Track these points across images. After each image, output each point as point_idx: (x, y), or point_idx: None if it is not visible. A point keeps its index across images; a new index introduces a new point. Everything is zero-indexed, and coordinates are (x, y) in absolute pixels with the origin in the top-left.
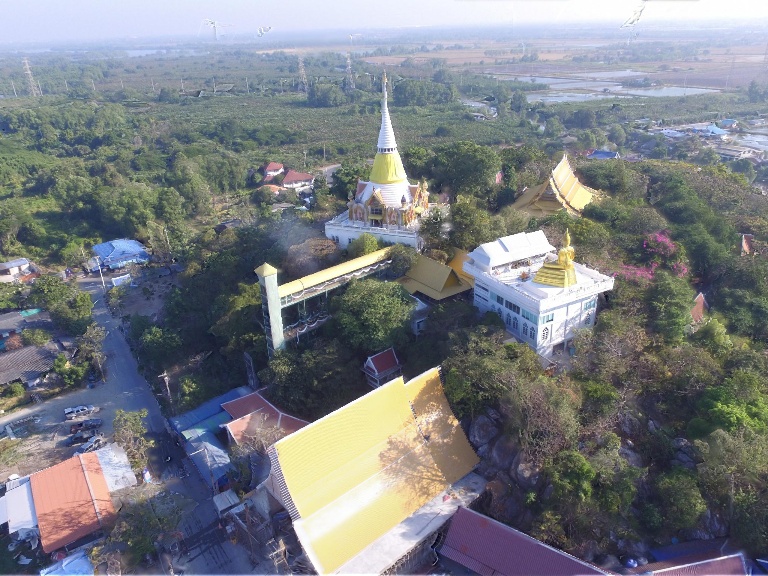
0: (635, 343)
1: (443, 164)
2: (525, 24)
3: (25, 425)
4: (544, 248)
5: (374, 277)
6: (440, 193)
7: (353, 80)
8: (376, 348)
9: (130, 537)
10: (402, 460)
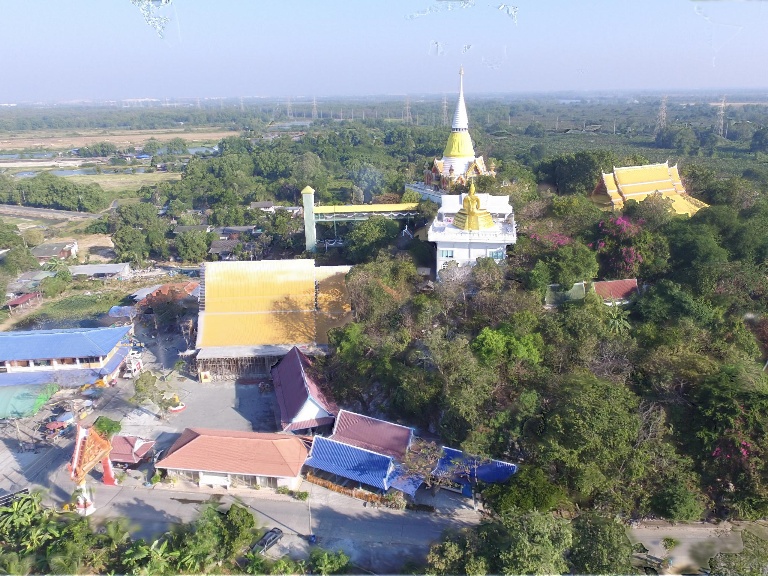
0: (484, 280)
1: (564, 163)
2: (720, 38)
3: None
4: (500, 209)
5: (410, 225)
6: (557, 190)
7: (726, 127)
8: (348, 257)
9: (151, 304)
10: (291, 313)
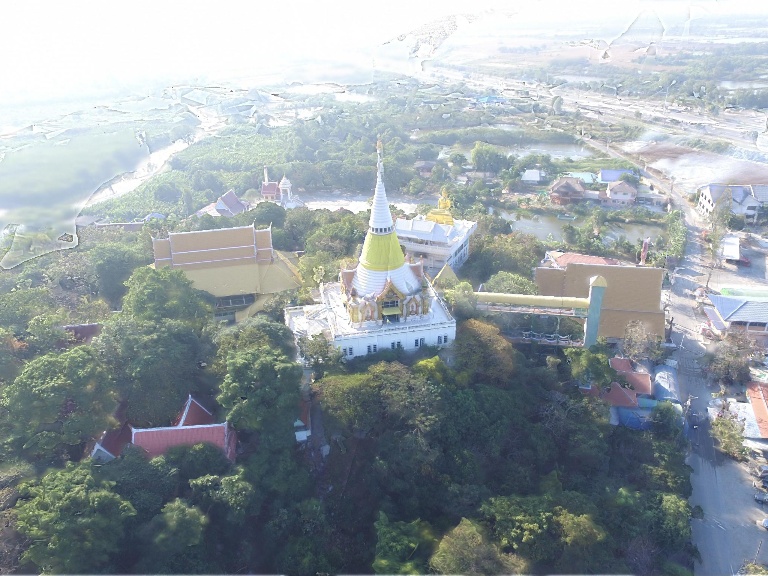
0: None
1: None
2: None
3: None
4: None
5: None
6: None
7: None
8: None
9: None
10: None
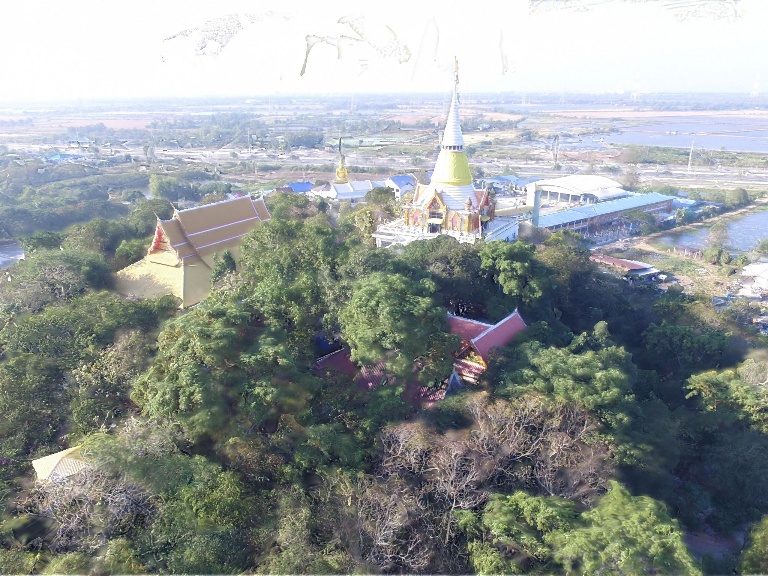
0: None
1: None
2: None
3: (715, 301)
4: None
5: None
6: None
7: None
8: None
9: None
10: None
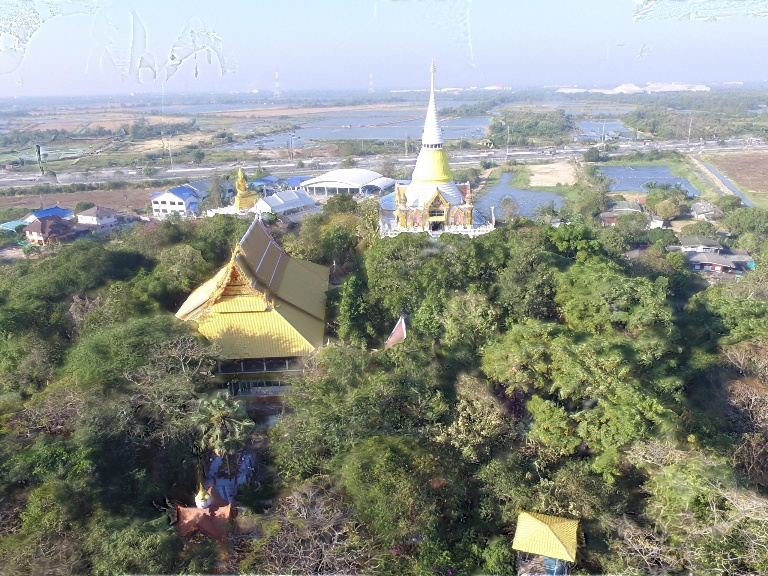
0: None
1: None
2: None
3: None
4: None
5: None
6: None
7: None
8: None
9: None
10: None
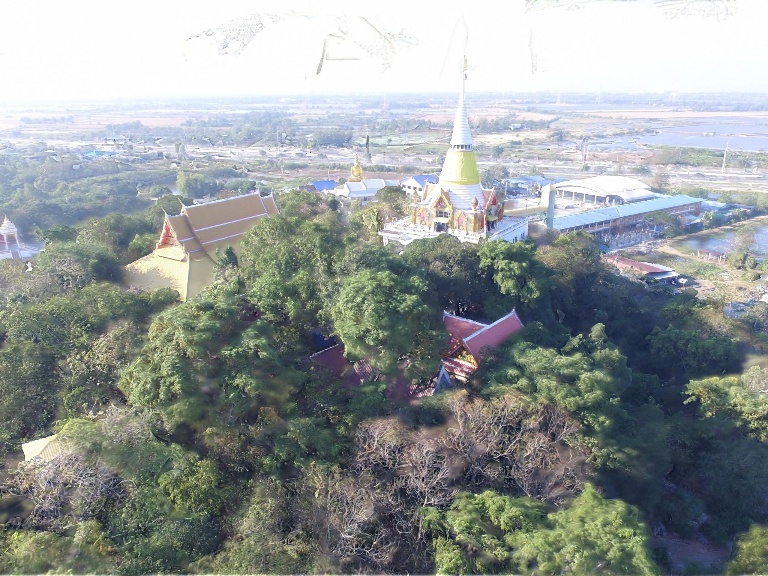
0: None
1: None
2: None
3: None
4: None
5: None
6: None
7: None
8: None
9: None
10: None
